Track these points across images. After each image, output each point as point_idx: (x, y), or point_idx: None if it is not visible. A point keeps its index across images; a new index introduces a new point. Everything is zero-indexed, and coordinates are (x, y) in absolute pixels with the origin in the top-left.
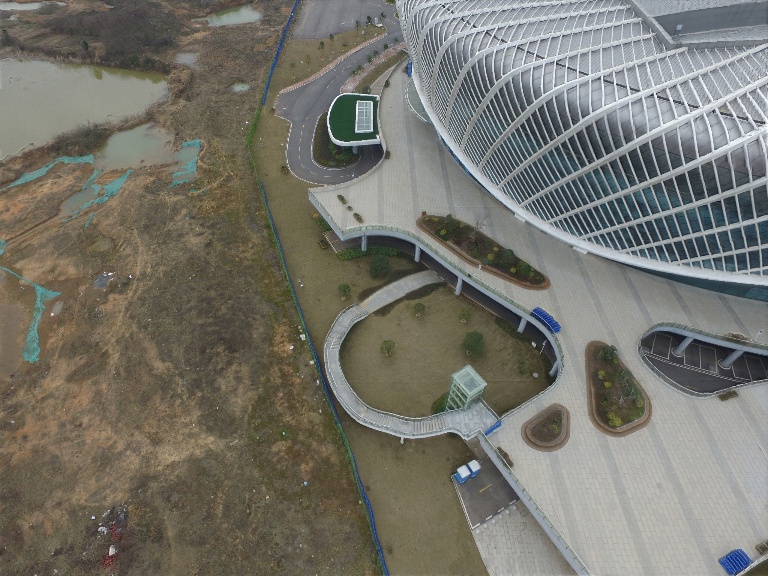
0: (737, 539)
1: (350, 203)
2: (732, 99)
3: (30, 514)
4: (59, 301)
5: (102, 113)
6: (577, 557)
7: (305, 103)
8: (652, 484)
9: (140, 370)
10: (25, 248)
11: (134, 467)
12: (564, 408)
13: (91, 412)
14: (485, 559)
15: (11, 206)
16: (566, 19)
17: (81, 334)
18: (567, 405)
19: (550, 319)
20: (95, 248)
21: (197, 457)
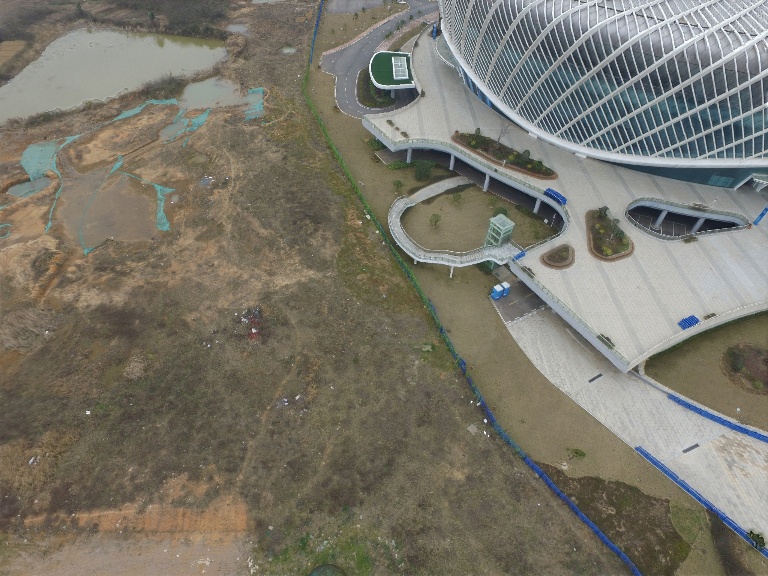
0: (691, 314)
1: (397, 126)
2: (687, 14)
3: (190, 313)
4: (175, 194)
5: (177, 68)
6: (581, 319)
7: (345, 62)
8: (633, 286)
9: (249, 234)
10: (139, 161)
11: (259, 288)
12: (570, 247)
13: (219, 258)
14: (516, 339)
15: (119, 133)
16: None
17: (198, 214)
18: (572, 245)
19: (559, 195)
20: (195, 161)
21: (303, 282)
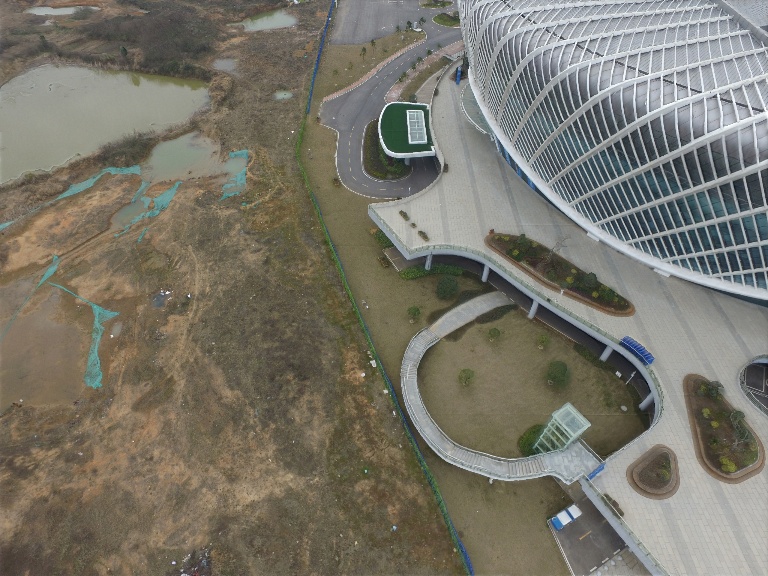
0: None
1: (413, 220)
2: None
3: (107, 557)
4: (118, 322)
5: (146, 122)
6: None
7: (350, 111)
8: None
9: (208, 398)
10: (79, 264)
11: (212, 506)
12: (669, 450)
13: (161, 444)
14: None
15: (61, 219)
16: (665, 31)
17: (143, 358)
18: (672, 446)
19: (642, 350)
20: (150, 265)
21: (277, 496)
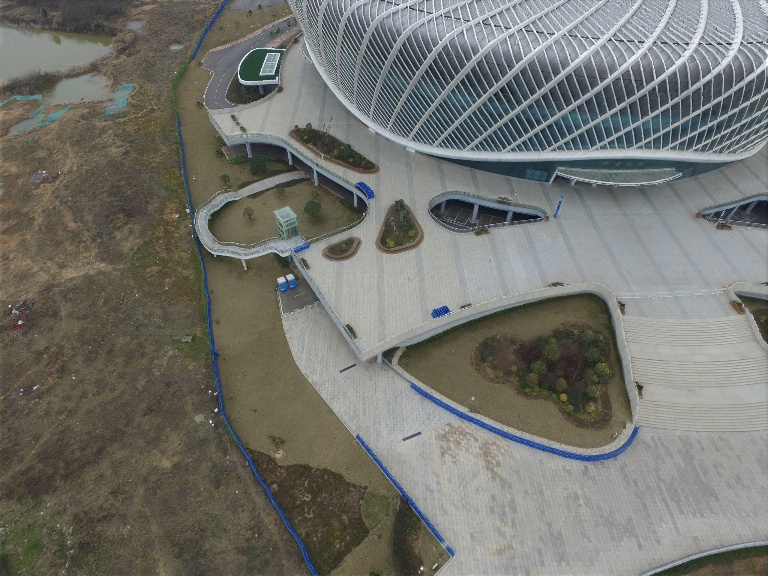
0: (450, 304)
1: (240, 121)
2: (455, 7)
3: None
4: (1, 188)
5: None
6: (332, 309)
7: (229, 59)
8: (404, 278)
9: (57, 227)
10: None
11: (43, 280)
12: (359, 239)
13: (16, 251)
14: (286, 330)
15: None
16: None
17: (16, 207)
18: (362, 237)
19: (367, 188)
20: (34, 155)
21: (90, 274)
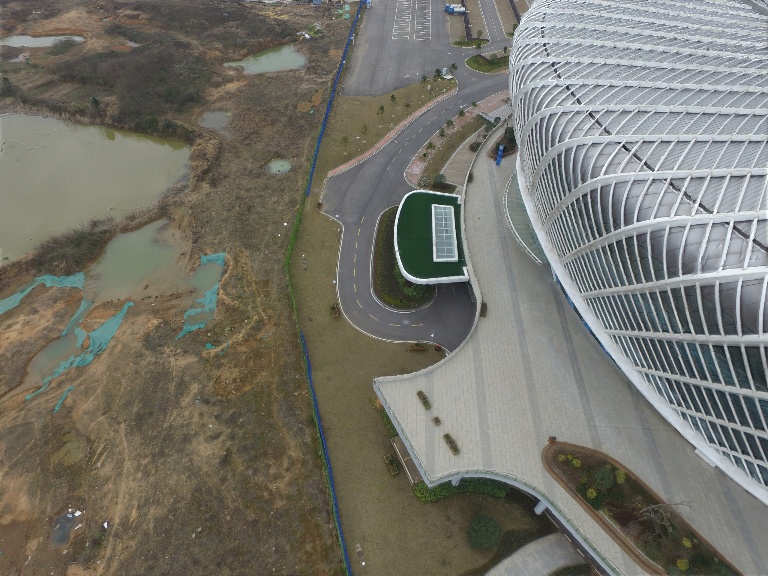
0: None
1: (436, 408)
2: None
3: None
4: None
5: (103, 205)
6: None
7: (360, 193)
8: None
9: None
10: None
11: None
12: None
13: None
14: None
15: None
16: None
17: None
18: None
19: None
20: (63, 457)
21: None
